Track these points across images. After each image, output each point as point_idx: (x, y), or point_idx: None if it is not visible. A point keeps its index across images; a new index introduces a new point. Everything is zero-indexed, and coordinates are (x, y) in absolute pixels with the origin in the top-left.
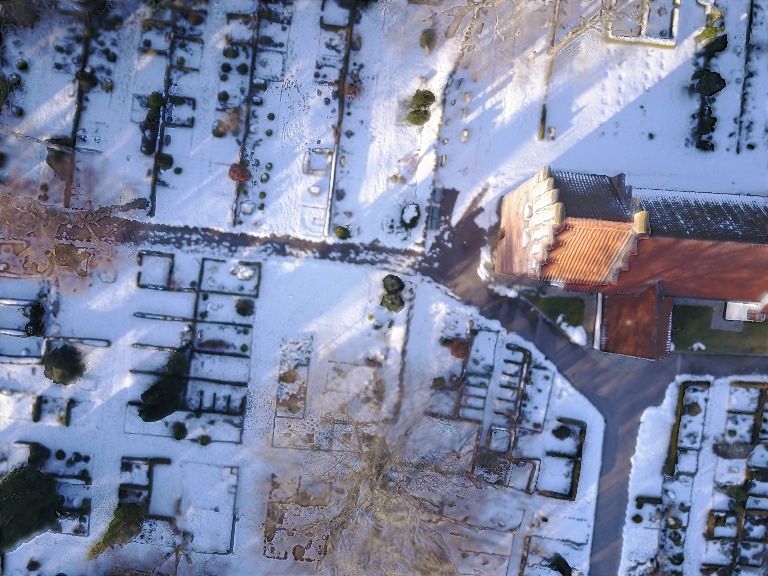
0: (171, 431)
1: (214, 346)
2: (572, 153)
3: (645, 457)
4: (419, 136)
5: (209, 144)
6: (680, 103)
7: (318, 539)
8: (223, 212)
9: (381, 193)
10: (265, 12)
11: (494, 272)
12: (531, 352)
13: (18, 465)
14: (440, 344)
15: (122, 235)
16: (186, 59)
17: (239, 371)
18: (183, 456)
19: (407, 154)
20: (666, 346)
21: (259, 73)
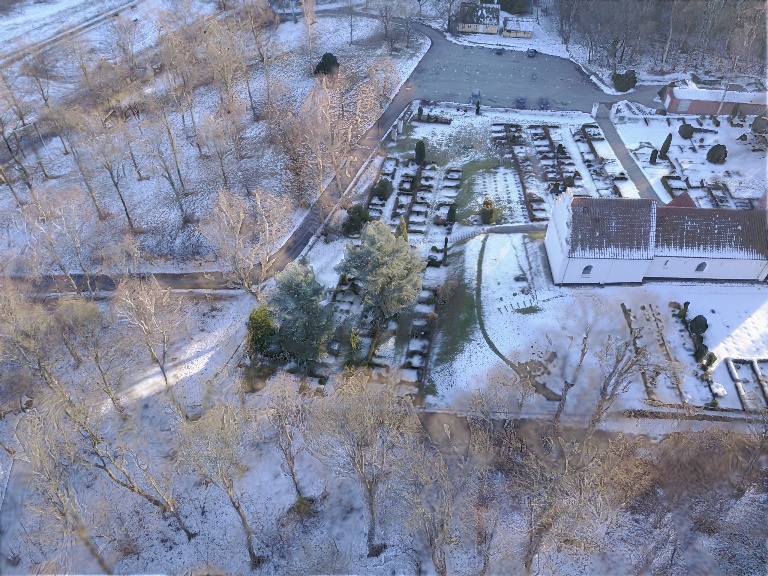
0: None
1: None
2: (761, 302)
3: (632, 192)
4: None
5: None
6: None
7: None
8: None
9: None
10: None
11: None
12: None
13: None
14: None
15: None
16: None
17: None
18: None
19: None
20: None
21: None
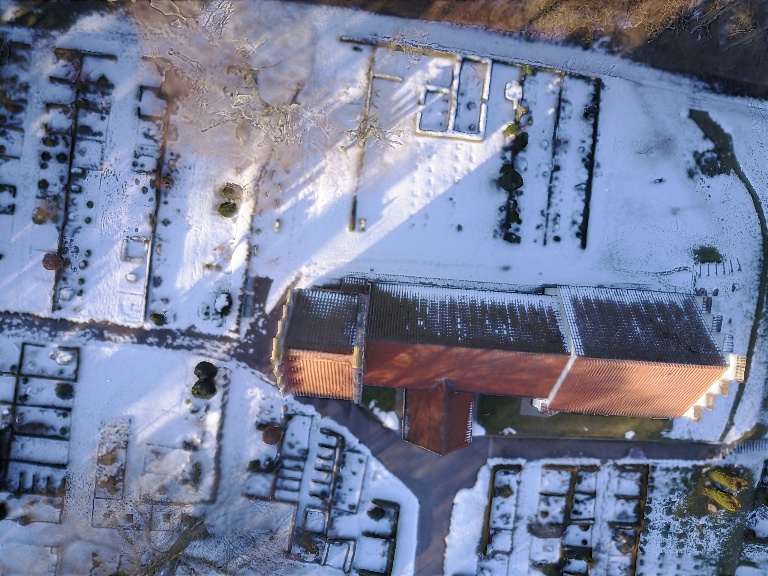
0: None
1: (33, 429)
2: (383, 244)
3: (459, 537)
4: (235, 225)
5: (29, 231)
6: (489, 195)
7: None
8: (43, 298)
9: (197, 280)
10: (81, 104)
11: None
12: (344, 436)
13: None
14: (255, 428)
15: None
16: (7, 147)
17: (58, 453)
18: (4, 536)
19: (223, 242)
20: (465, 436)
21: (78, 162)
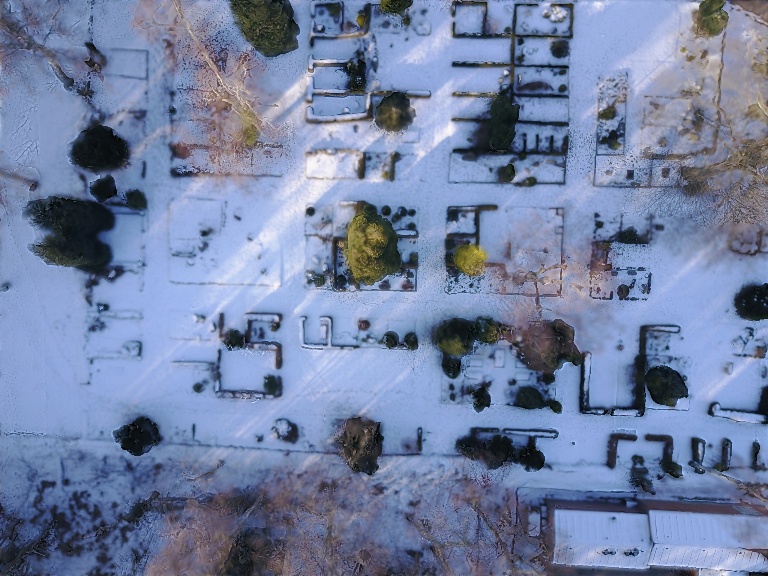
0: (496, 176)
1: (533, 89)
2: None
3: None
4: None
5: None
6: None
7: (641, 278)
8: None
9: None
10: None
11: None
12: None
13: (342, 226)
14: (753, 71)
15: None
16: None
17: (559, 112)
18: (508, 201)
19: None
20: None
21: None
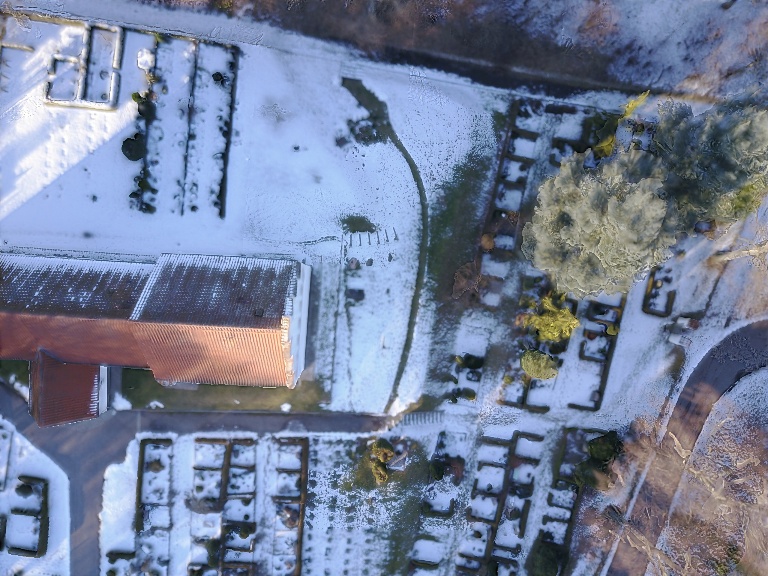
0: None
1: None
2: (16, 216)
3: (113, 513)
4: None
5: None
6: (124, 166)
7: None
8: None
9: None
10: None
11: None
12: None
13: None
14: None
15: None
16: None
17: None
18: None
19: None
20: (89, 409)
21: None
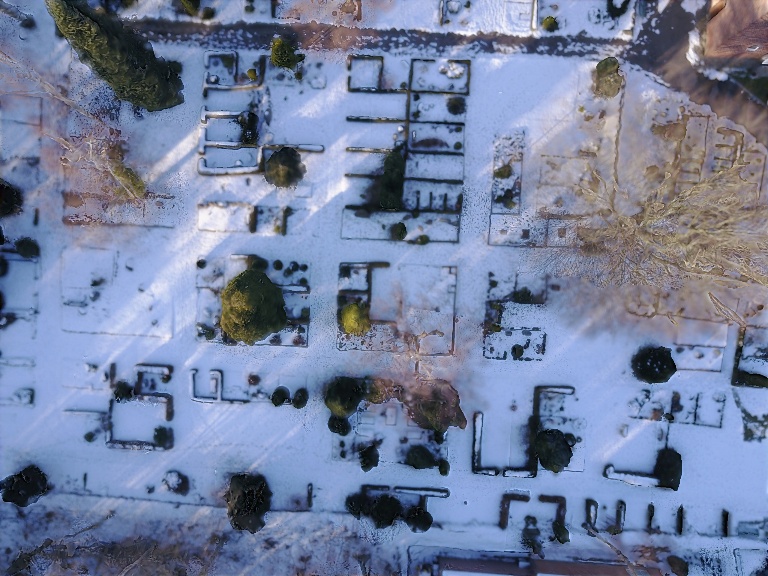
0: (388, 233)
1: (428, 146)
2: None
3: None
4: None
5: None
6: None
7: (536, 338)
8: (429, 13)
9: None
10: None
11: (704, 55)
12: (743, 134)
13: None
14: (652, 132)
15: (329, 42)
16: None
17: (453, 169)
18: (401, 259)
19: None
20: None
21: None
